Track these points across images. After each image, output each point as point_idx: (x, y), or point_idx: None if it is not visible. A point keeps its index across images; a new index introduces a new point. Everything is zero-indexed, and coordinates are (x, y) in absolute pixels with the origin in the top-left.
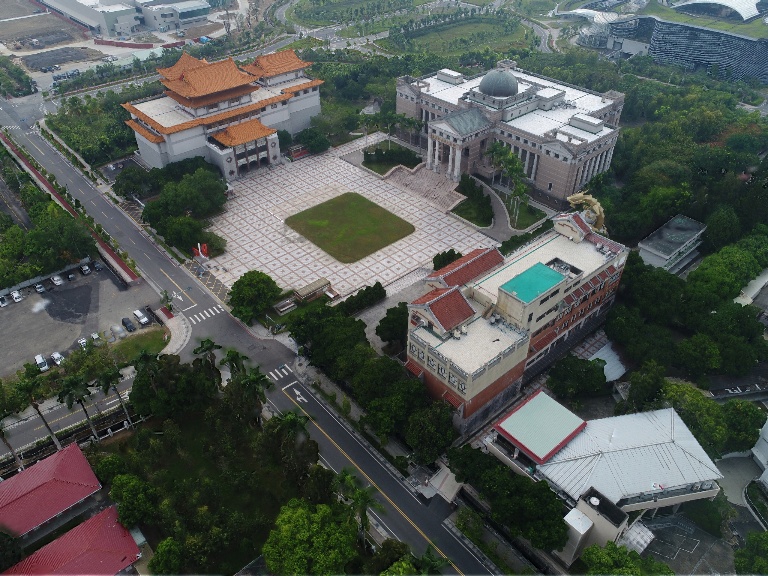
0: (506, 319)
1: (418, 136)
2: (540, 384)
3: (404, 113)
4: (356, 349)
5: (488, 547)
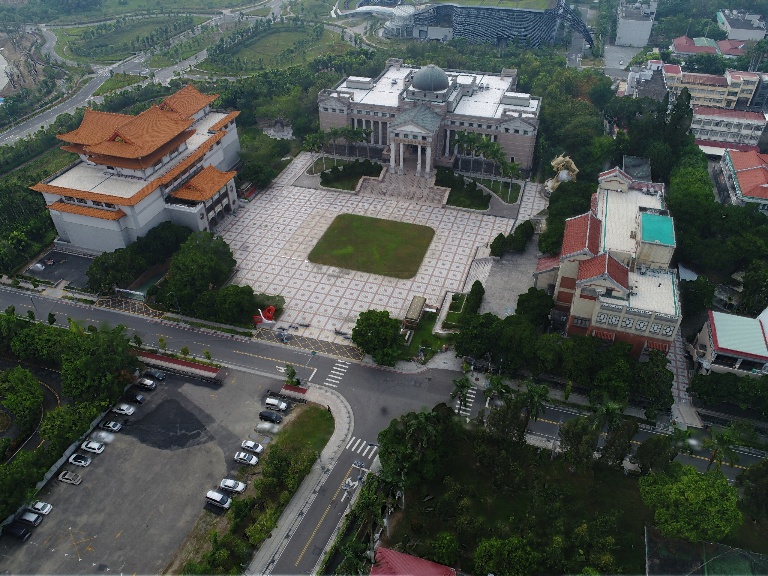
0: (648, 266)
1: (352, 146)
2: None
3: (347, 125)
4: (545, 339)
5: (760, 444)
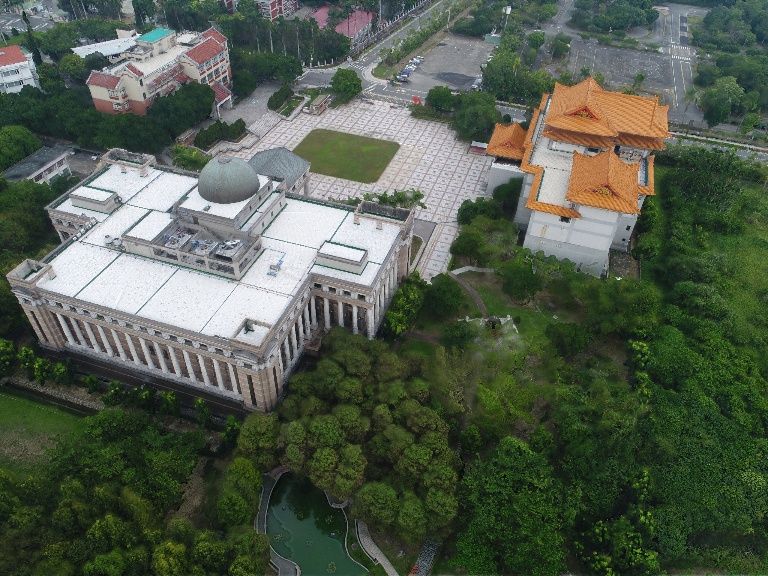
0: None
1: None
2: None
3: (365, 198)
4: None
5: None
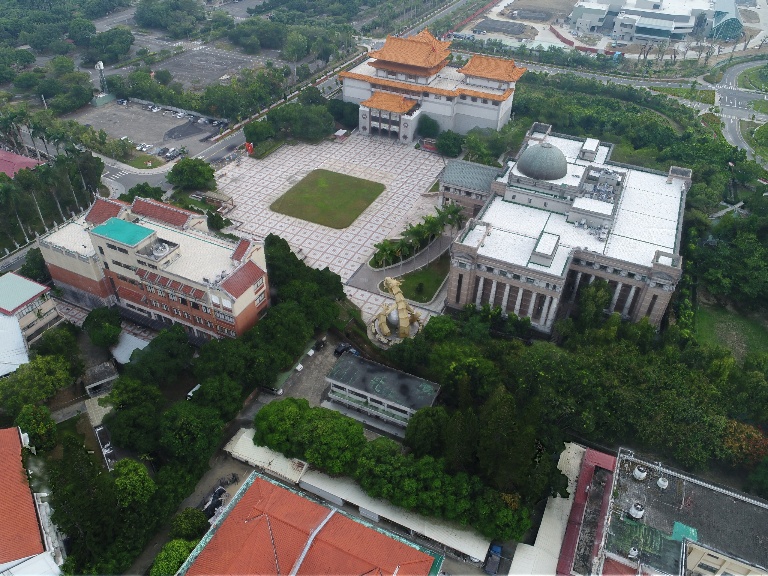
0: None
1: None
2: (124, 327)
3: None
4: None
5: None
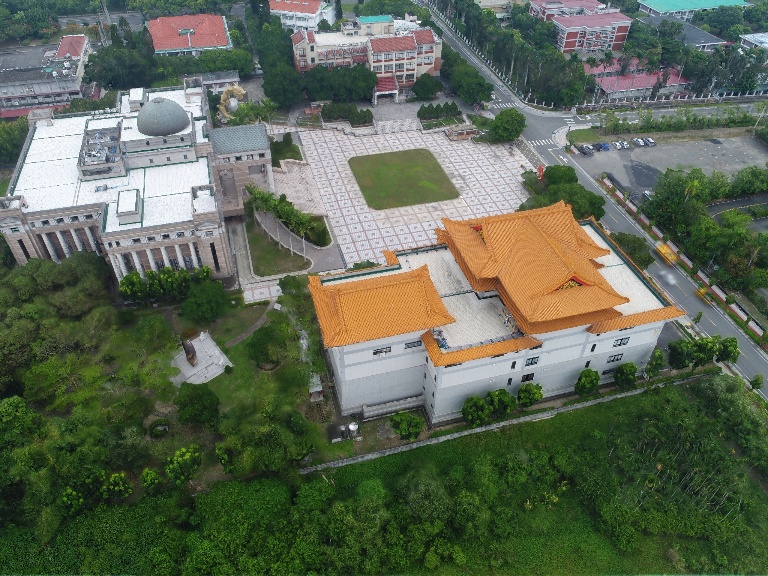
0: None
1: None
2: None
3: (259, 194)
4: (463, 68)
5: None
